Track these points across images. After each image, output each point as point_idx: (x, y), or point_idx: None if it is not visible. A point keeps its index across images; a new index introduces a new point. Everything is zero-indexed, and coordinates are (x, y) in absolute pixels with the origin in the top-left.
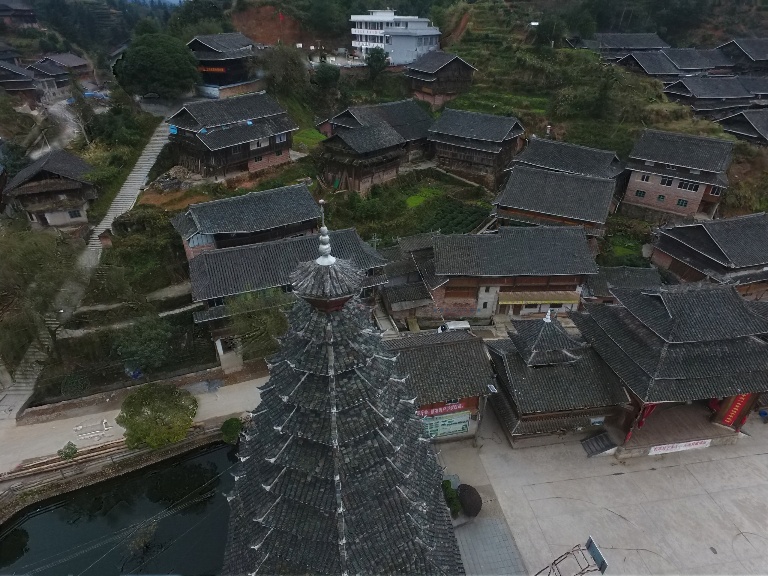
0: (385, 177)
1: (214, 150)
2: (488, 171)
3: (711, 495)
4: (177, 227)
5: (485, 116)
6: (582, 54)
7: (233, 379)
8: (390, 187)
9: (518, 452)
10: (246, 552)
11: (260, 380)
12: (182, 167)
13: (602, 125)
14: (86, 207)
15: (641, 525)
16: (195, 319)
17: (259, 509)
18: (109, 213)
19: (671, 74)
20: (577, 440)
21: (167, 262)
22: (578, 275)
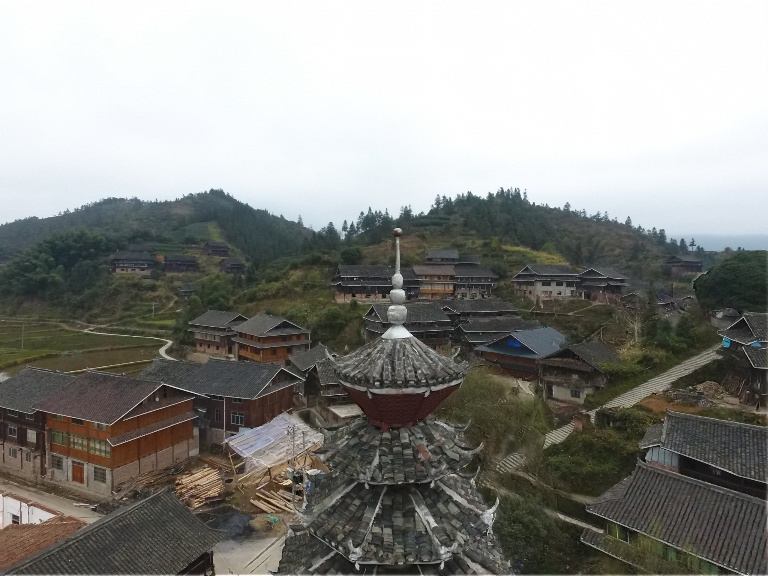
0: None
1: (759, 368)
2: None
3: None
4: (648, 433)
5: None
6: None
7: None
8: None
9: None
10: None
11: None
12: (717, 384)
13: None
14: (589, 391)
15: None
16: (582, 535)
17: None
18: (607, 405)
19: None
20: None
21: (627, 473)
22: None
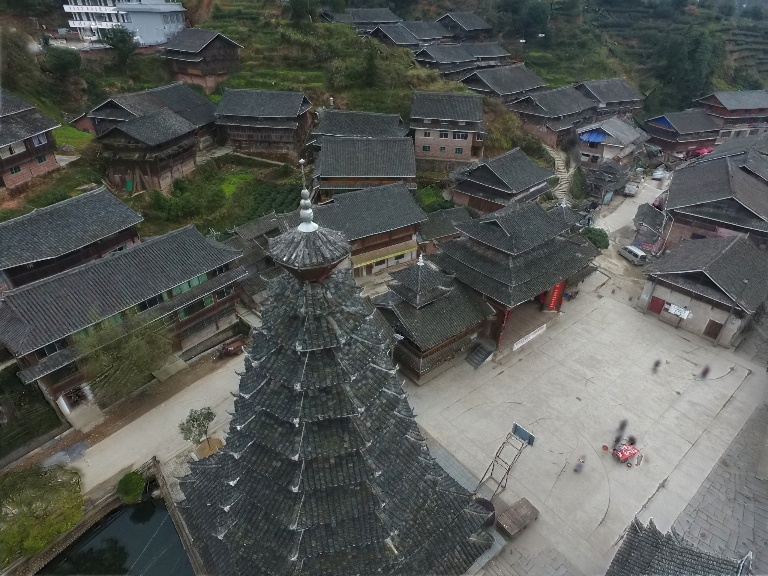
0: (184, 170)
1: None
2: (289, 148)
3: (561, 362)
4: None
5: (271, 93)
6: (340, 28)
7: (98, 435)
8: (193, 180)
9: (424, 387)
10: (273, 574)
11: (135, 423)
12: None
13: (377, 92)
14: None
15: (531, 403)
16: (24, 380)
17: (285, 518)
18: None
19: (414, 44)
20: (462, 360)
21: None
22: (412, 225)
